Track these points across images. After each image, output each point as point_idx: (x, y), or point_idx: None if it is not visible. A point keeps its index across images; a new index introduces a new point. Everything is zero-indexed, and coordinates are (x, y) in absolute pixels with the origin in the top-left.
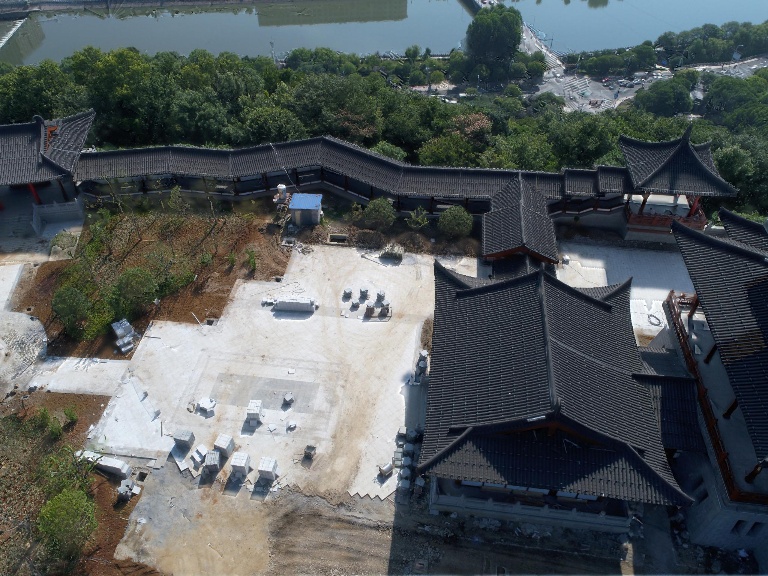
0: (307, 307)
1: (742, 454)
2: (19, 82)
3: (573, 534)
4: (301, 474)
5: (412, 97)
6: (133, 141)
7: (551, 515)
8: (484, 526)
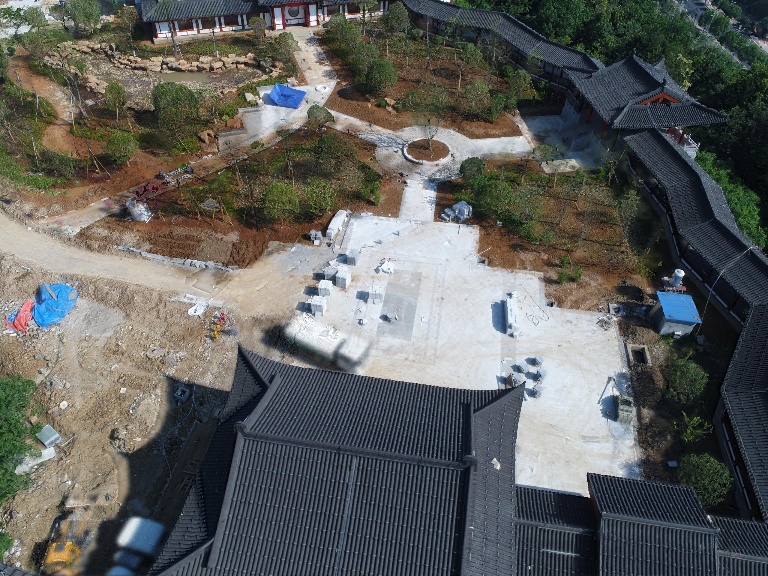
0: None
1: None
2: (758, 74)
3: None
4: (315, 330)
5: None
6: (758, 181)
7: None
8: None
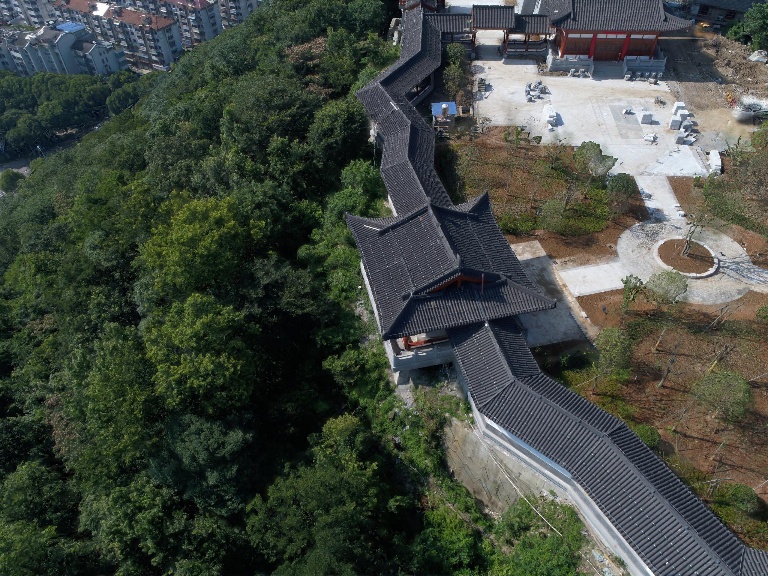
0: None
1: None
2: (221, 340)
3: None
4: None
5: (183, 112)
6: None
7: None
8: None
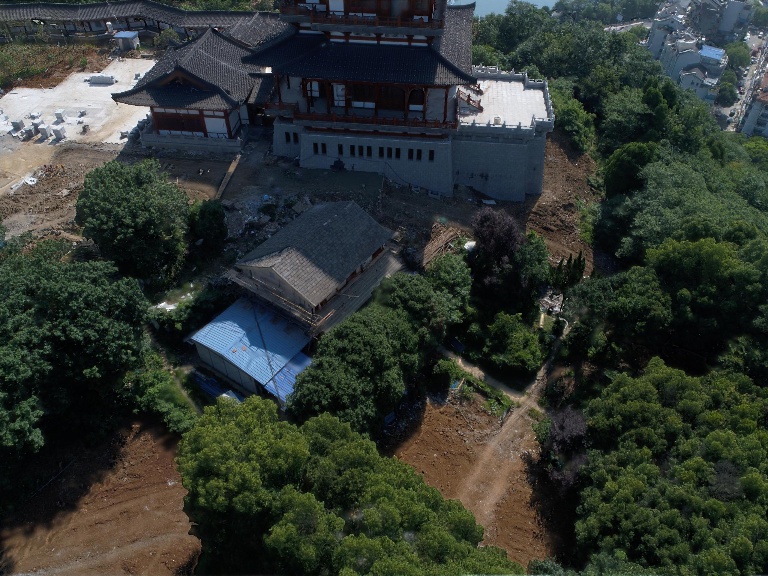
0: (109, 80)
1: (285, 98)
2: None
3: (214, 154)
4: (79, 137)
5: None
6: None
7: (201, 143)
8: (168, 152)
